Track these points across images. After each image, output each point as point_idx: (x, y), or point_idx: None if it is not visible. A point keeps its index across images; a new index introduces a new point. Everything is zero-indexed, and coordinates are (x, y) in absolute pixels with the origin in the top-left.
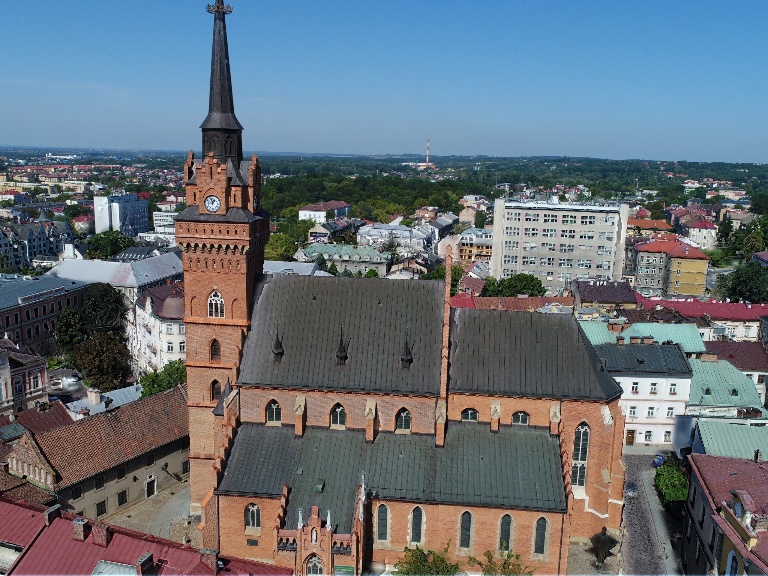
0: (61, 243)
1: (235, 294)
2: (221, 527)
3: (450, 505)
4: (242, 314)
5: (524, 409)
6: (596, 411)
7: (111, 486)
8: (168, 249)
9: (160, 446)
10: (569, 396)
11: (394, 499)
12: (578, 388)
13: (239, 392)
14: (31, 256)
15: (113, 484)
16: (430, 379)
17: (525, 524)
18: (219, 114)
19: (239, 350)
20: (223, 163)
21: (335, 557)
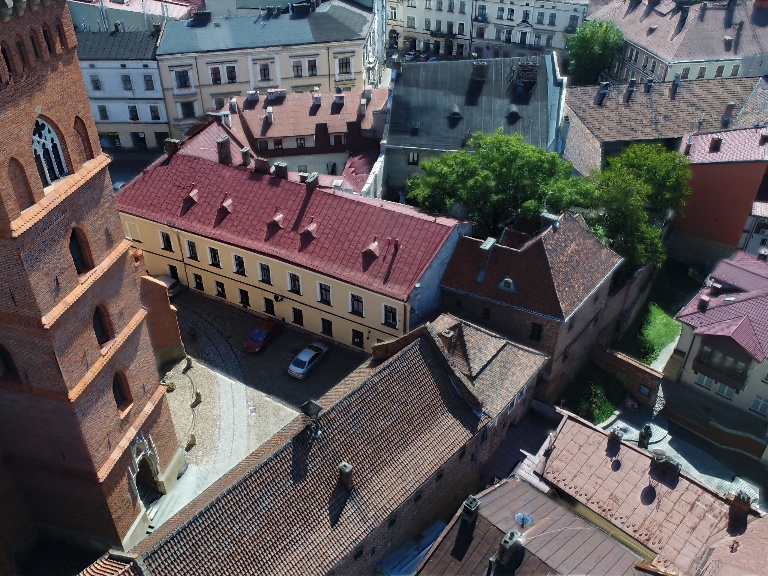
0: None
1: None
2: None
3: None
4: None
5: None
6: None
7: None
8: None
9: None
10: None
11: None
12: None
13: None
14: None
15: None
16: None
17: None
18: None
19: None
20: None
21: None
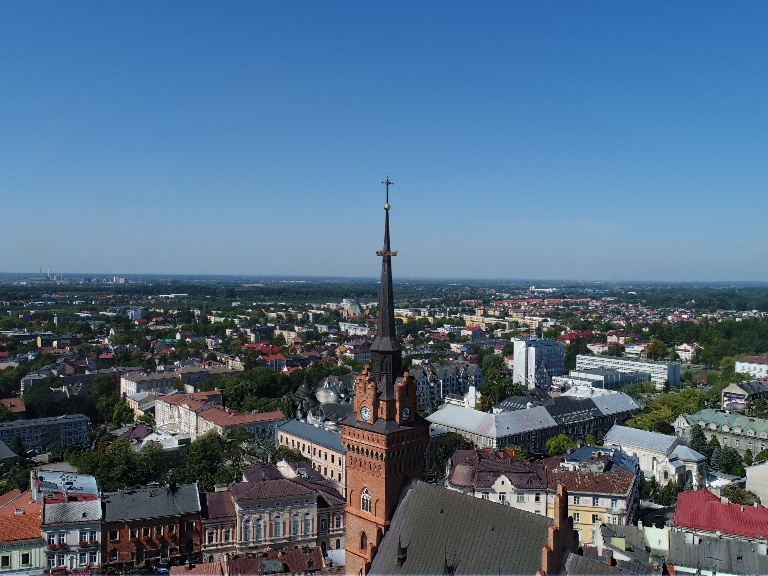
0: (467, 384)
1: (378, 494)
2: None
3: None
4: (382, 514)
5: None
6: None
7: None
8: (542, 402)
9: None
10: None
11: None
12: None
13: None
14: (444, 393)
15: None
16: None
17: None
18: (380, 338)
19: (372, 547)
20: (379, 379)
21: None
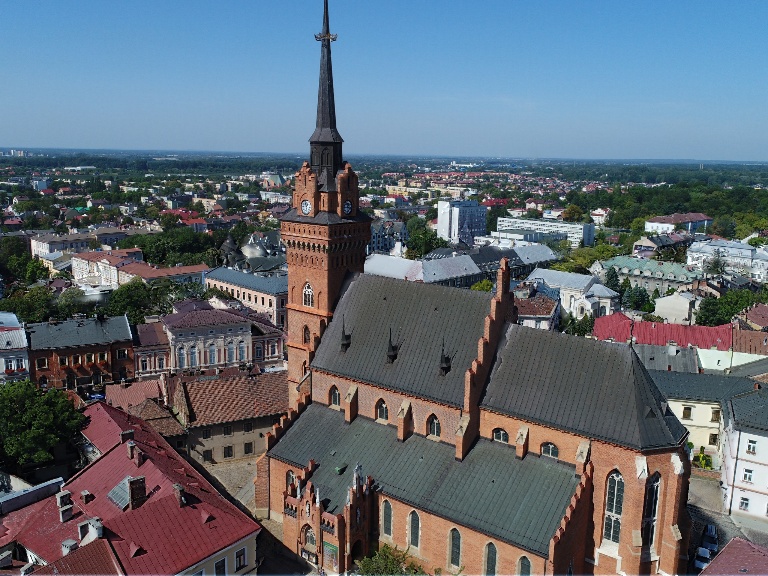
0: (393, 241)
1: (320, 287)
2: (271, 485)
3: (440, 517)
4: (325, 306)
5: (553, 441)
6: (630, 460)
7: (238, 436)
8: (467, 252)
9: (285, 412)
10: (599, 436)
11: (394, 497)
12: (613, 429)
13: (311, 374)
14: (370, 250)
15: (240, 434)
16: (460, 390)
17: (508, 558)
18: (320, 129)
19: (315, 337)
20: (319, 172)
21: (324, 533)
